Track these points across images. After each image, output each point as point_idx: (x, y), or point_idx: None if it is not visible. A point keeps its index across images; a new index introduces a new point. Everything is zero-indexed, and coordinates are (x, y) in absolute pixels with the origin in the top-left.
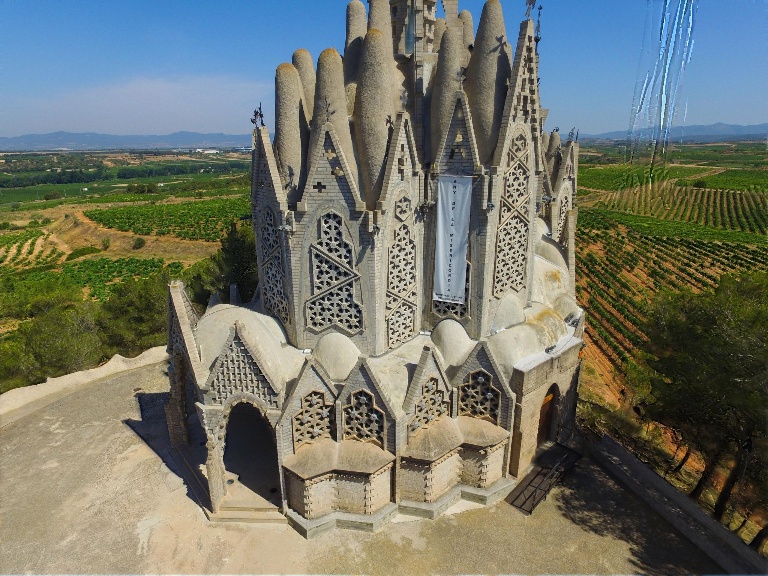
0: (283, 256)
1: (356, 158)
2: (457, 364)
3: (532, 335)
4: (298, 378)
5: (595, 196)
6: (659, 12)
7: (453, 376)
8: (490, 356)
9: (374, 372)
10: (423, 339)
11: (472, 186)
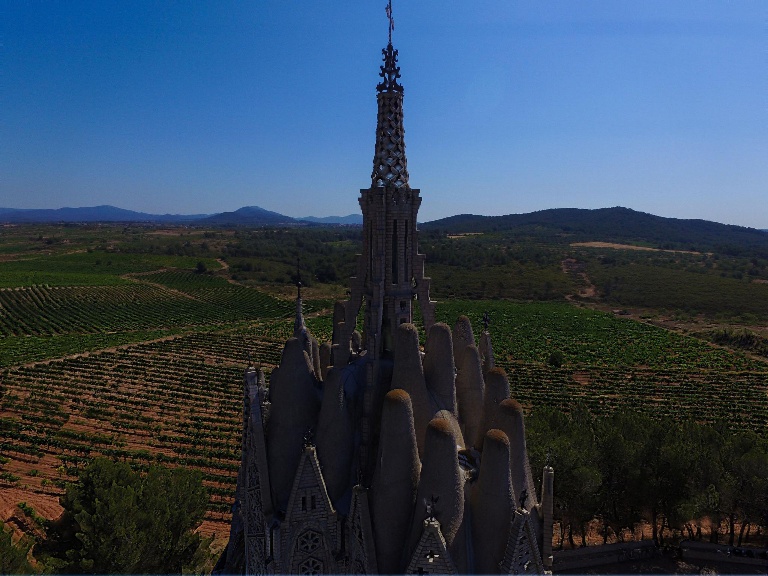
0: None
1: None
2: None
3: None
4: None
5: None
6: None
7: None
8: None
9: None
10: None
11: None
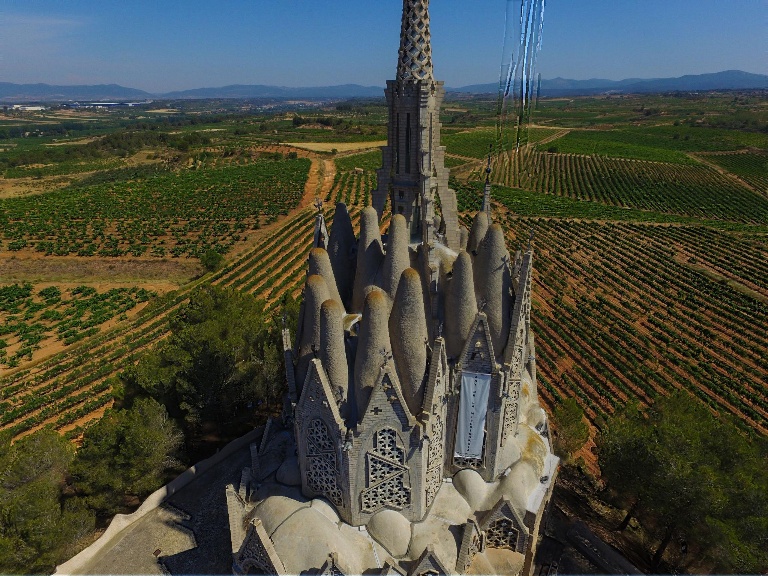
0: (338, 459)
1: (396, 370)
2: (481, 509)
3: (531, 472)
4: None
5: (469, 165)
6: (519, 0)
7: (479, 520)
8: (512, 509)
9: (439, 556)
10: (448, 488)
11: (490, 380)
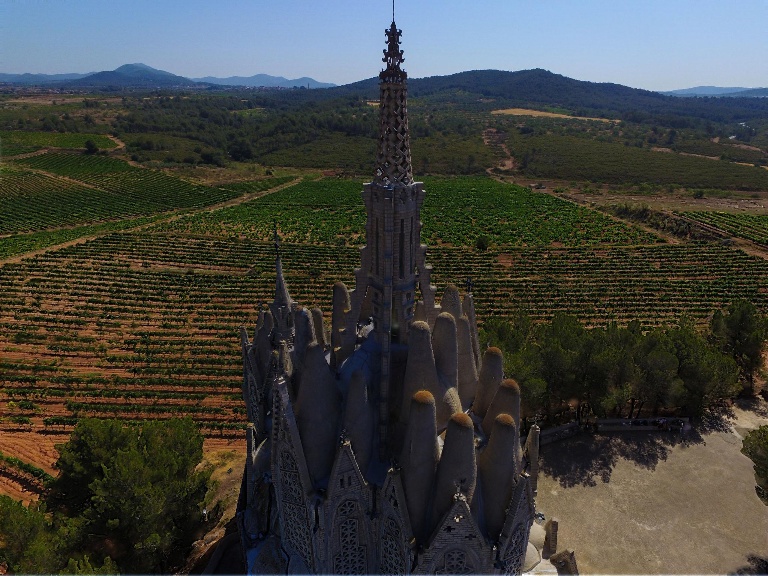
0: None
1: None
2: None
3: None
4: (575, 566)
5: None
6: None
7: None
8: None
9: None
10: None
11: None
